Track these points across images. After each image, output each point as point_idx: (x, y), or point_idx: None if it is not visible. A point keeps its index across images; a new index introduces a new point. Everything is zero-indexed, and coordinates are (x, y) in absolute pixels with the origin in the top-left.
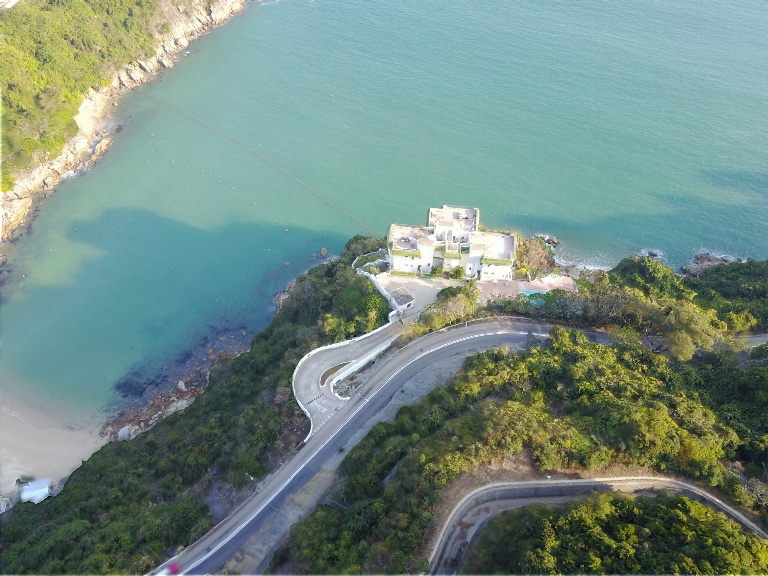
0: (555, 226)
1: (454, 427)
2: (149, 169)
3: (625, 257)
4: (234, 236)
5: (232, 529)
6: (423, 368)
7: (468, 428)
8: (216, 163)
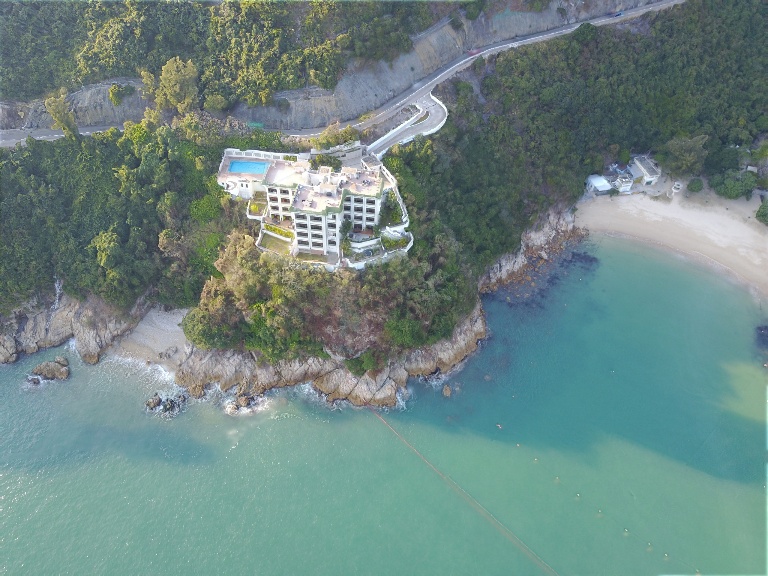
0: (135, 435)
1: (358, 8)
2: (757, 570)
3: (117, 282)
4: (563, 419)
5: (464, 63)
6: (360, 116)
7: (351, 5)
8: (654, 574)
